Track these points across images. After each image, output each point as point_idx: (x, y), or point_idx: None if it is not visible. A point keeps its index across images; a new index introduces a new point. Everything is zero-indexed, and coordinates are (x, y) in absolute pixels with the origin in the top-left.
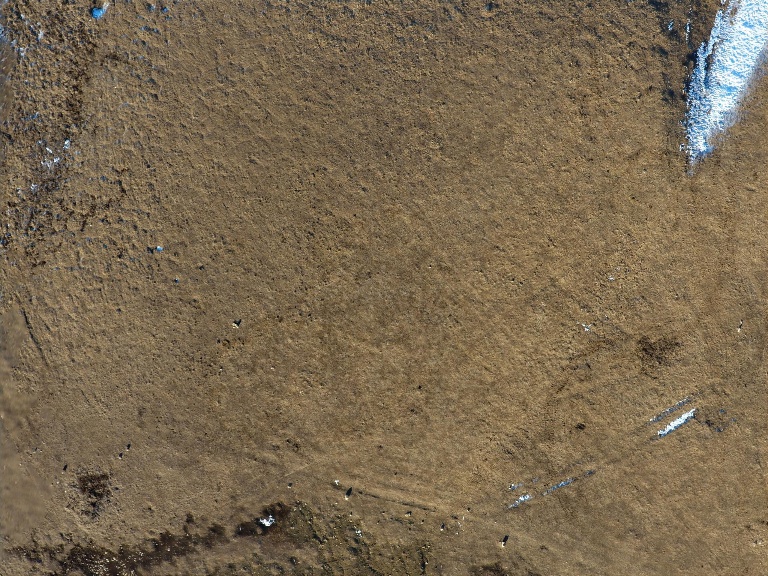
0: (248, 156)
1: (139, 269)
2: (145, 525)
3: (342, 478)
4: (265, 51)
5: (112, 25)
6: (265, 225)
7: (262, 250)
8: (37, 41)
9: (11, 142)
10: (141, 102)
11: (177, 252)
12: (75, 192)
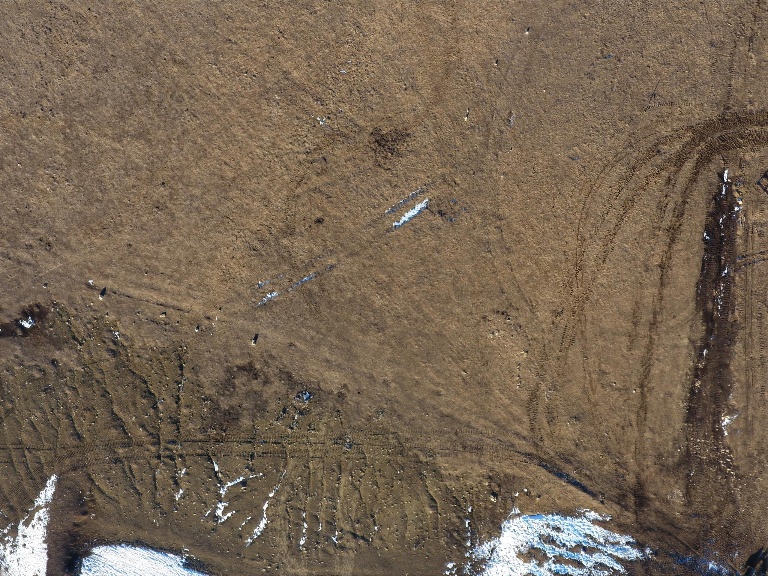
0: None
1: None
2: None
3: (95, 278)
4: None
5: None
6: (5, 21)
7: (3, 46)
8: None
9: None
10: None
11: None
12: None
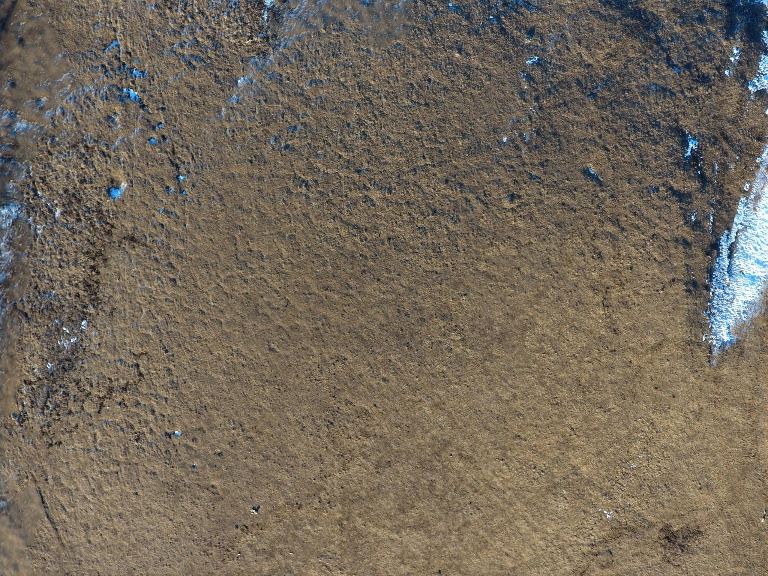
0: (267, 344)
1: (157, 454)
2: None
3: None
4: (285, 239)
5: (130, 206)
6: (284, 413)
7: (281, 438)
8: (54, 219)
9: (27, 320)
10: (159, 286)
11: (195, 438)
12: (92, 373)
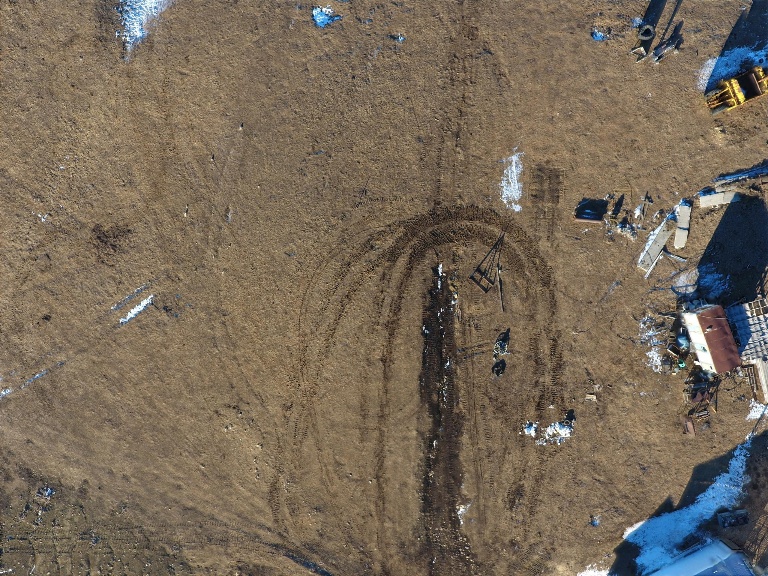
0: None
1: None
2: None
3: None
4: None
5: None
6: None
7: None
8: None
9: None
10: None
11: None
12: None
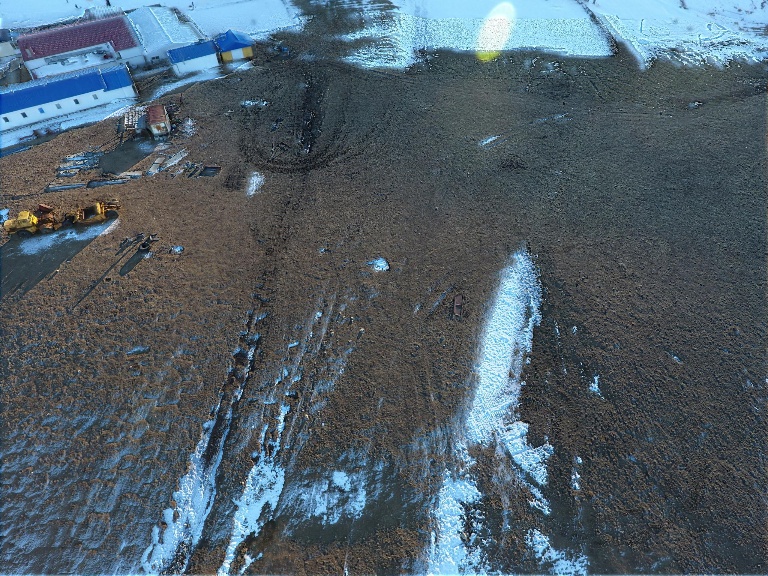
0: None
1: None
2: (765, 98)
3: None
4: None
5: None
6: None
7: None
8: None
9: None
10: None
11: None
12: None
